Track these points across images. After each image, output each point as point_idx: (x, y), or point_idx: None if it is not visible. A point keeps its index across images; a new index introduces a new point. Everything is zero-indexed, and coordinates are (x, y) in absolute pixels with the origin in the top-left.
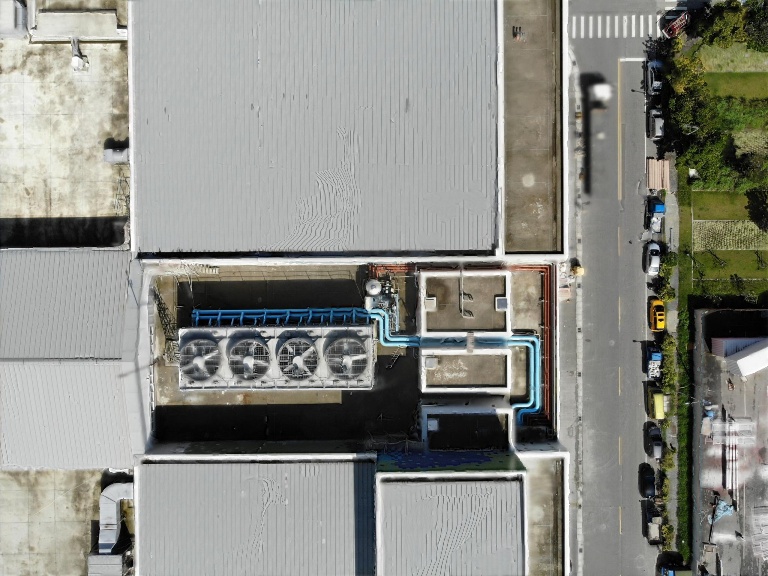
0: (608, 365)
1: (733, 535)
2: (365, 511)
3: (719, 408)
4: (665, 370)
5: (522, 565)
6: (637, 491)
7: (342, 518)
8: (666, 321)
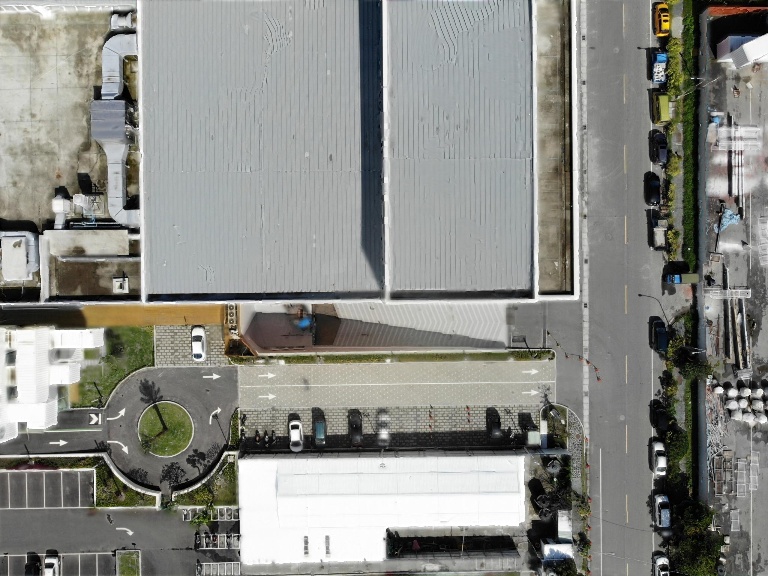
0: (613, 73)
1: (739, 244)
2: (370, 39)
3: (725, 116)
4: (670, 71)
5: (530, 42)
6: (642, 200)
7: (347, 48)
8: (671, 27)
